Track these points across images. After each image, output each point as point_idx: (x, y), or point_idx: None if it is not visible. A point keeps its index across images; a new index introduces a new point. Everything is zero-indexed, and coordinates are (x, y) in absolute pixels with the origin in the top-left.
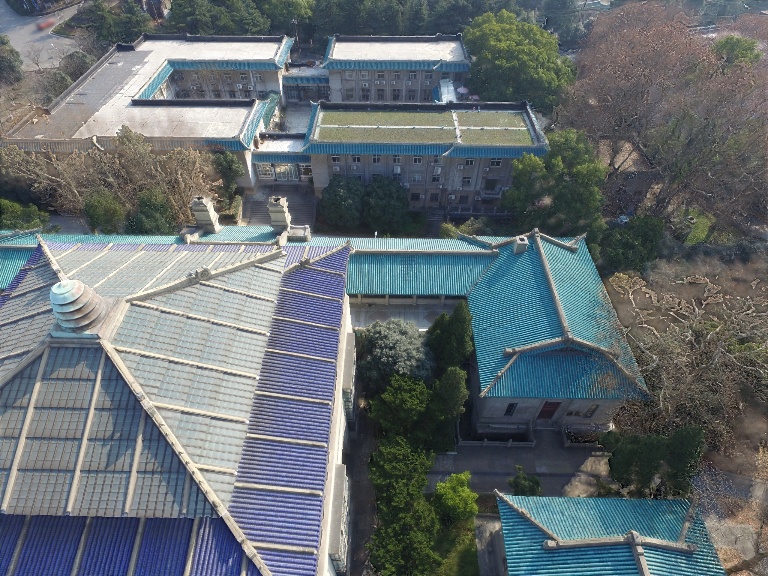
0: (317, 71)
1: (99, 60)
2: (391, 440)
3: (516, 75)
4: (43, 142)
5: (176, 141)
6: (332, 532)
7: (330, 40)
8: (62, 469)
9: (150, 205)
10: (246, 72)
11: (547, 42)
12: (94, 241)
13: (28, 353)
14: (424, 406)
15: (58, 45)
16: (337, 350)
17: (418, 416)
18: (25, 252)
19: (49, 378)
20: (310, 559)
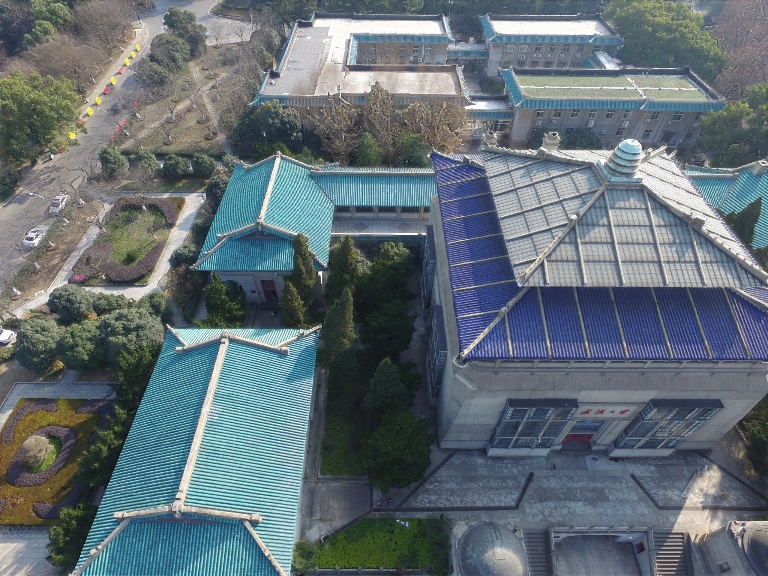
0: (471, 46)
1: (292, 34)
2: None
3: (675, 45)
4: (296, 98)
5: (409, 97)
6: None
7: (482, 19)
8: (650, 261)
9: (419, 145)
10: (419, 45)
11: (695, 18)
12: (395, 171)
13: (585, 195)
14: None
15: (234, 23)
16: None
17: None
18: (351, 177)
19: (614, 208)
20: None
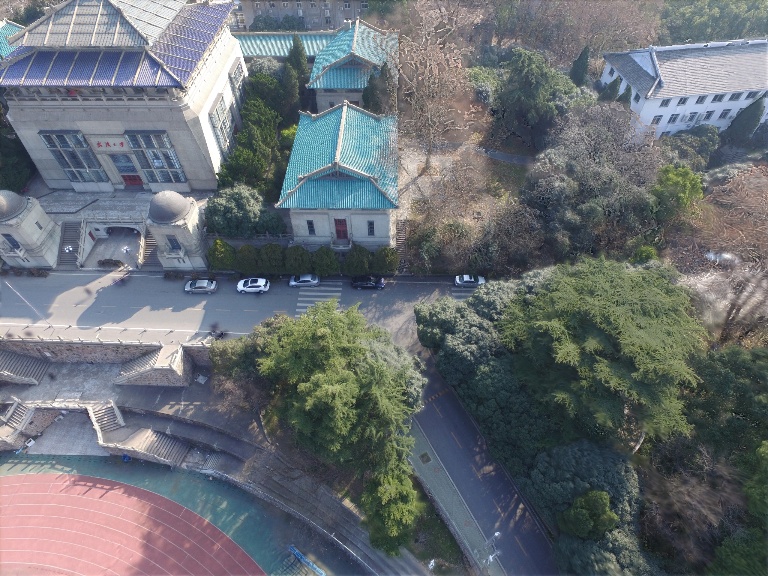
0: None
1: None
2: (254, 99)
3: None
4: None
5: None
6: (211, 108)
7: None
8: (88, 33)
9: None
10: None
11: None
12: None
13: None
14: (273, 86)
15: None
16: (216, 32)
17: (272, 96)
18: None
19: (81, 5)
20: (188, 73)
